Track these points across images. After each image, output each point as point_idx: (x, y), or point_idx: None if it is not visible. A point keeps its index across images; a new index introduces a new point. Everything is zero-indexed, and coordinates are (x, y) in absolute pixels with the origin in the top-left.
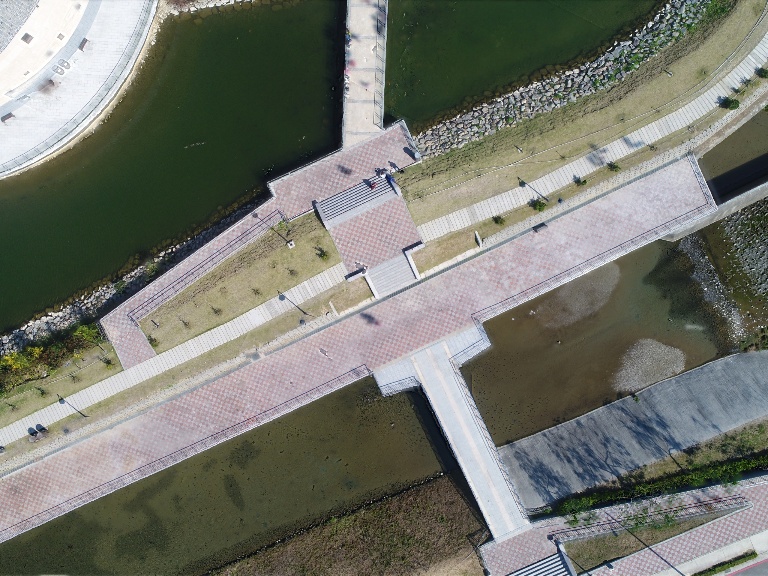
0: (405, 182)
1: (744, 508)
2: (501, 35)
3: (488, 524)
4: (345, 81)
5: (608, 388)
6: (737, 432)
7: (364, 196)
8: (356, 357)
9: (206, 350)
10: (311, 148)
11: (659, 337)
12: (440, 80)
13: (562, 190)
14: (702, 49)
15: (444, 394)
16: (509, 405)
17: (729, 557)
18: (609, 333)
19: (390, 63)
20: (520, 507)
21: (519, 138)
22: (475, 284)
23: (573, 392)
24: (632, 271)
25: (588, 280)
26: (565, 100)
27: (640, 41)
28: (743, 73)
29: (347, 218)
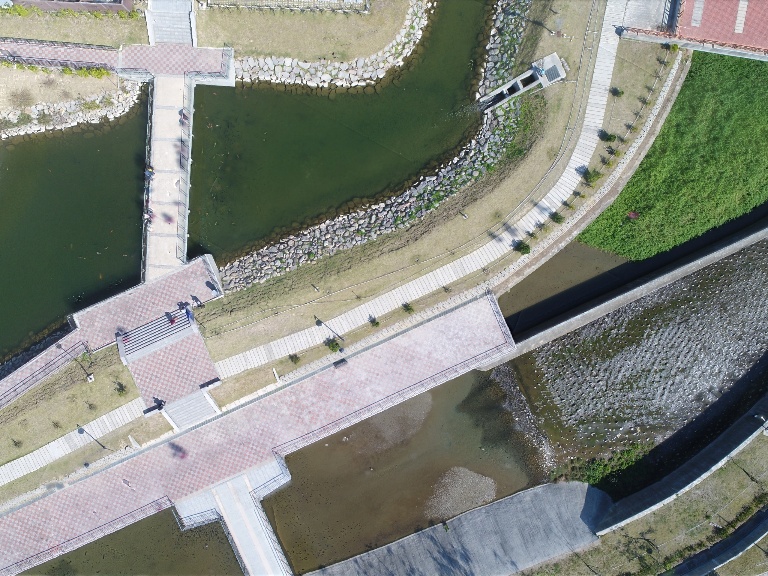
0: (204, 318)
1: None
2: (311, 166)
3: None
4: (144, 217)
5: (420, 515)
6: (533, 570)
7: (164, 331)
8: (158, 488)
9: (6, 481)
10: (121, 276)
11: (471, 465)
12: (250, 210)
13: (358, 330)
14: (497, 192)
15: (245, 527)
16: (322, 530)
17: None
18: (421, 461)
19: (201, 192)
20: None
21: (317, 276)
22: (276, 418)
23: (385, 518)
24: (445, 399)
25: (401, 408)
26: (366, 237)
27: (443, 178)
28: (537, 217)
29: (146, 353)
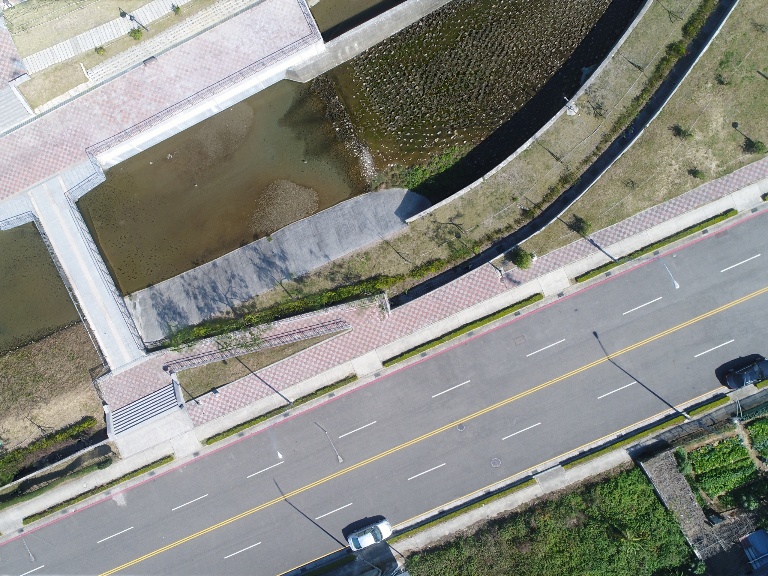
0: (12, 16)
1: (344, 332)
2: None
3: (105, 356)
4: None
5: (245, 230)
6: (345, 260)
7: None
8: None
9: None
10: None
11: (293, 178)
12: None
13: (161, 19)
14: None
15: (60, 228)
16: (149, 249)
17: (331, 381)
18: (245, 175)
19: None
20: (136, 339)
21: None
22: (88, 118)
23: (211, 234)
24: (266, 113)
25: (223, 123)
26: None
27: None
28: None
29: None
